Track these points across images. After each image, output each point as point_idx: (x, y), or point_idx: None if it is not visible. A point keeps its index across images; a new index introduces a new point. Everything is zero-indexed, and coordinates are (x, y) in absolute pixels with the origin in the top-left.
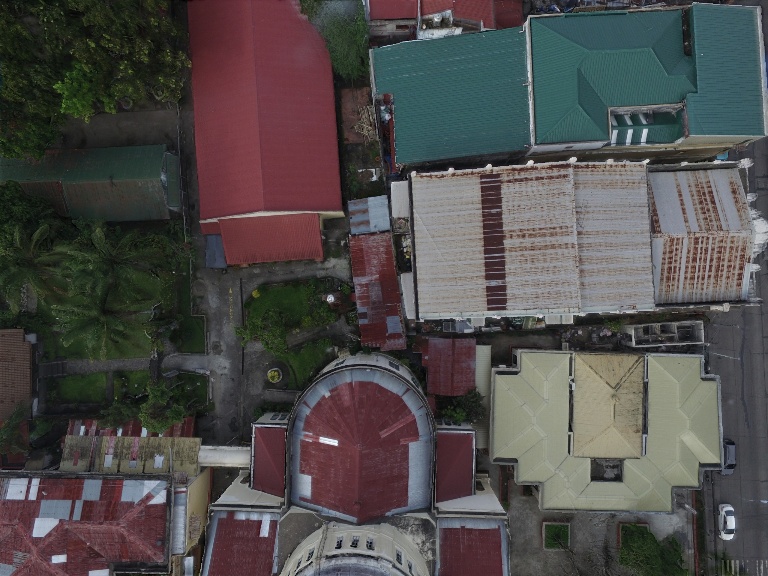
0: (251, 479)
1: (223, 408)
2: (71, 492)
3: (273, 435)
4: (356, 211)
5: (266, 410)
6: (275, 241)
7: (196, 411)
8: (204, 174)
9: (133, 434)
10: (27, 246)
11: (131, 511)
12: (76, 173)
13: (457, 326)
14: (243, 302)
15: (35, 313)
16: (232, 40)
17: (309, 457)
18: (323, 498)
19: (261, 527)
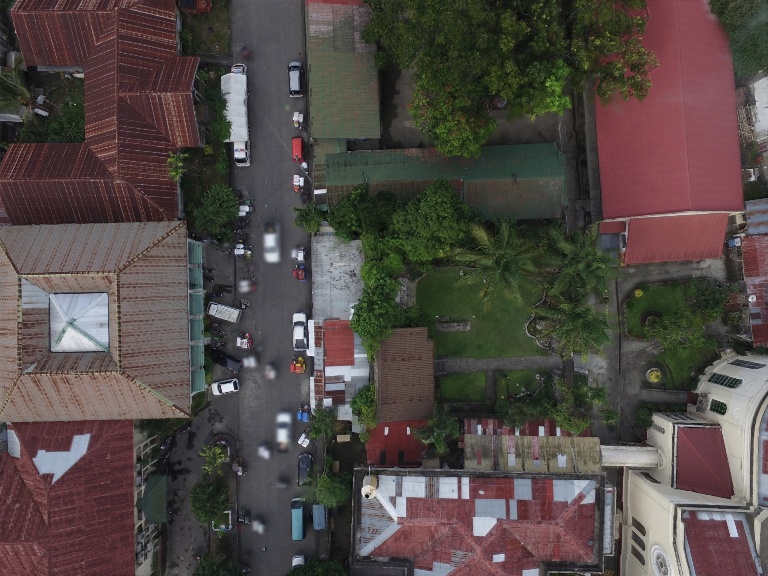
0: (674, 479)
1: (600, 408)
2: (503, 491)
3: (698, 435)
4: (755, 211)
5: (651, 410)
6: (678, 241)
7: None
8: (610, 173)
9: (531, 433)
10: (498, 244)
11: (567, 511)
12: (476, 171)
13: None
14: (619, 301)
15: None
16: (650, 38)
17: None
18: None
19: (728, 527)
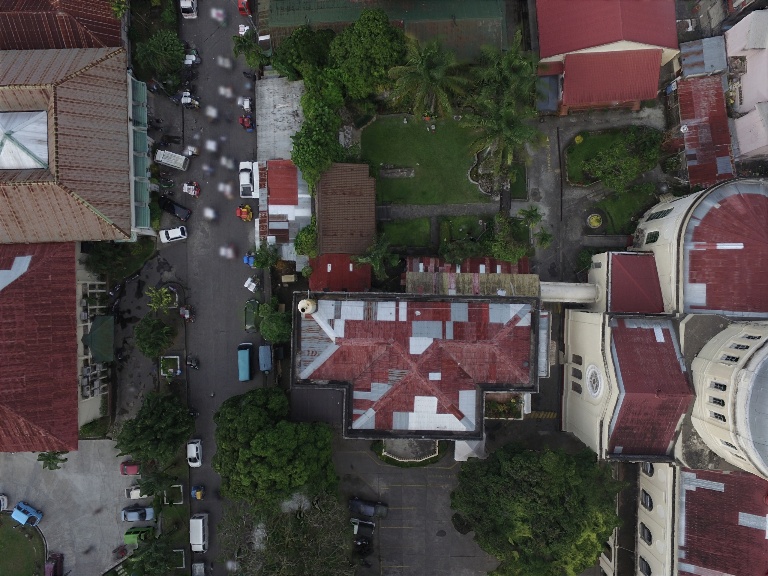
0: (608, 305)
1: (543, 253)
2: (440, 314)
3: (631, 261)
4: (690, 53)
5: (591, 253)
6: (614, 80)
7: None
8: (546, 13)
9: (472, 271)
10: None
11: (502, 331)
12: (416, 13)
13: None
14: (560, 150)
15: (360, 158)
16: None
17: (702, 265)
18: (724, 302)
19: (655, 334)
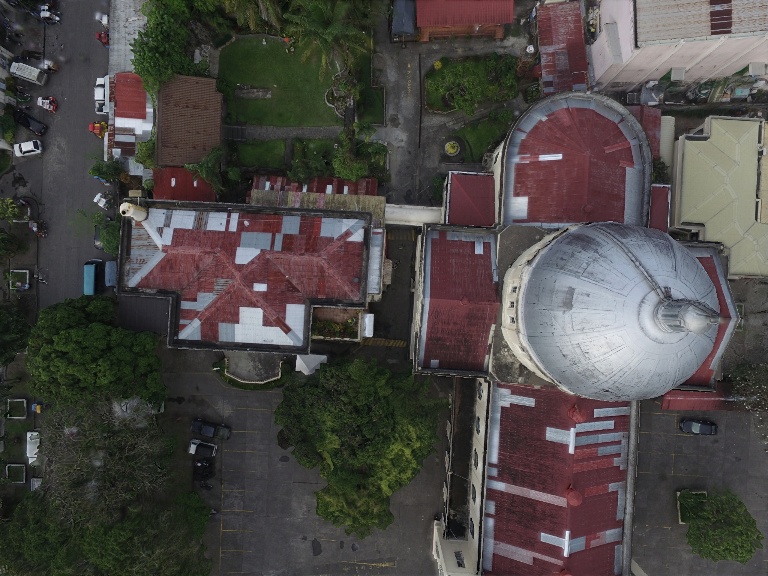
0: None
1: (399, 180)
2: (271, 226)
3: (470, 181)
4: None
5: None
6: (468, 2)
7: (377, 176)
8: None
9: (318, 191)
10: None
11: (331, 245)
12: None
13: (642, 98)
14: (421, 77)
15: None
16: None
17: (526, 178)
18: (543, 214)
19: (475, 247)
